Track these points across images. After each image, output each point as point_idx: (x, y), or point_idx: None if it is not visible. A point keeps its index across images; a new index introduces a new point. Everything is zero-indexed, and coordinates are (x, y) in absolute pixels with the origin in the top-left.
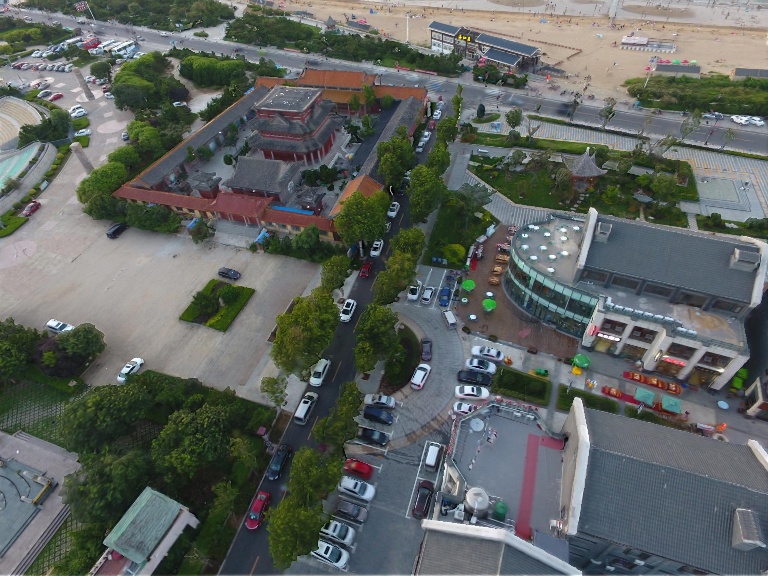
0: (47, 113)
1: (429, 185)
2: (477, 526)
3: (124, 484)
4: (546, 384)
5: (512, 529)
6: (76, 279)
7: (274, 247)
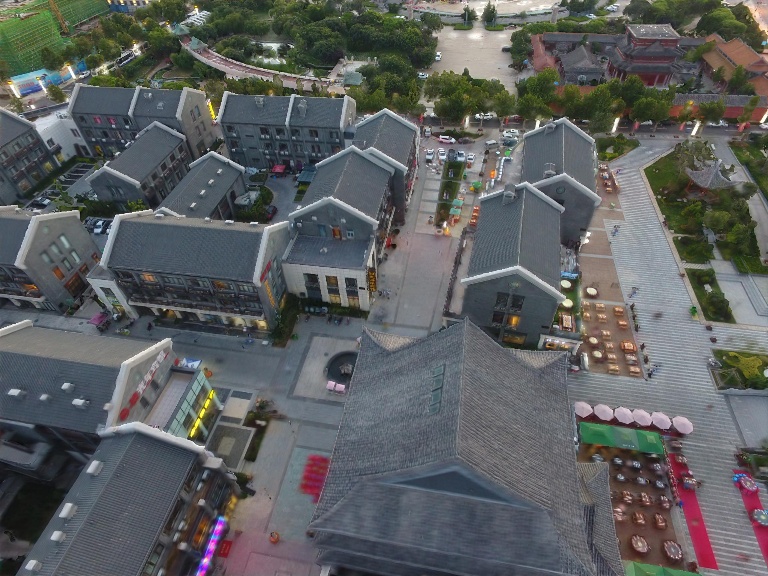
0: (602, 2)
1: (589, 95)
2: None
3: (365, 72)
4: (457, 177)
5: None
6: (469, 52)
7: (517, 84)
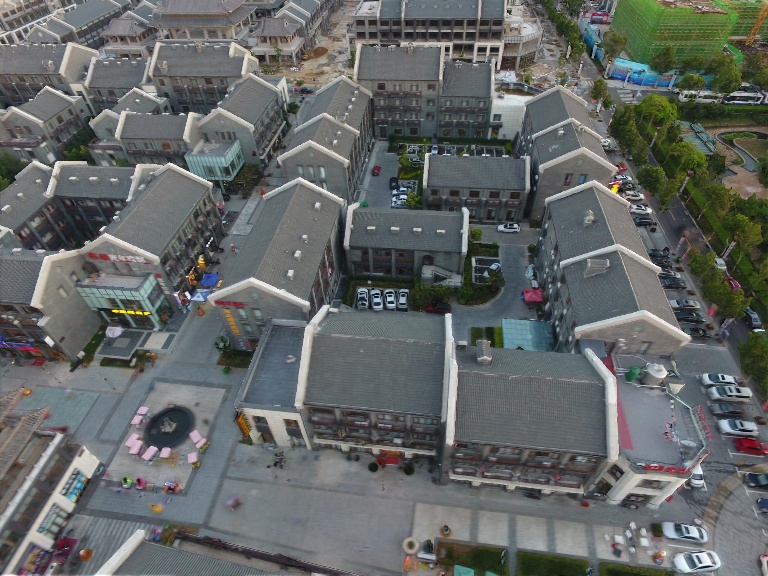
0: None
1: None
2: (661, 322)
3: None
4: None
5: (617, 370)
6: None
7: None
